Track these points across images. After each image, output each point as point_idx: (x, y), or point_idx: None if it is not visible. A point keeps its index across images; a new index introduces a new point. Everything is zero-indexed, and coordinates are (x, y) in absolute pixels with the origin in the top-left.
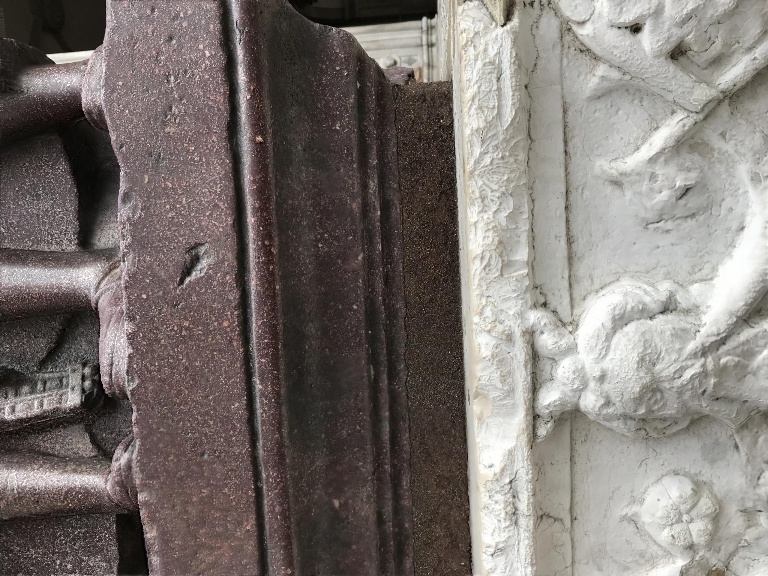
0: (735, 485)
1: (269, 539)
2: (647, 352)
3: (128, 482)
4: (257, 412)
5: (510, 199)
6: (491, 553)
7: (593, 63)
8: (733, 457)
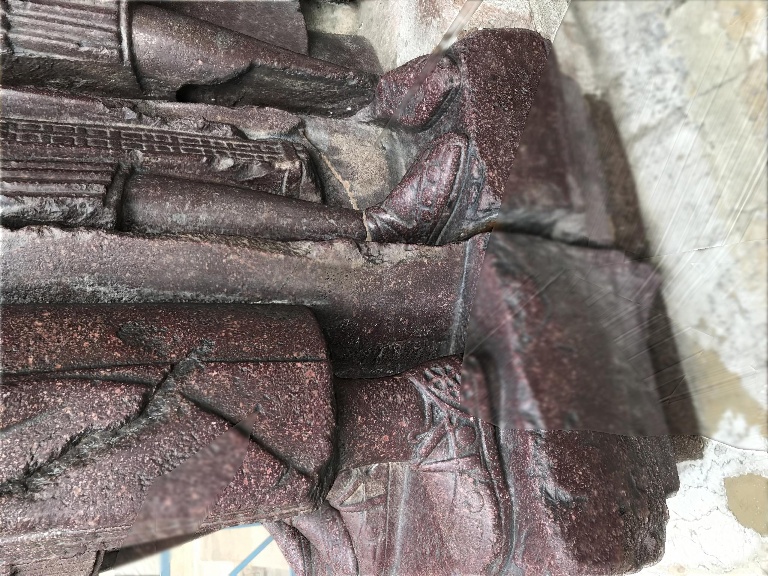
0: None
1: None
2: None
3: None
4: None
5: None
6: None
7: None
8: None
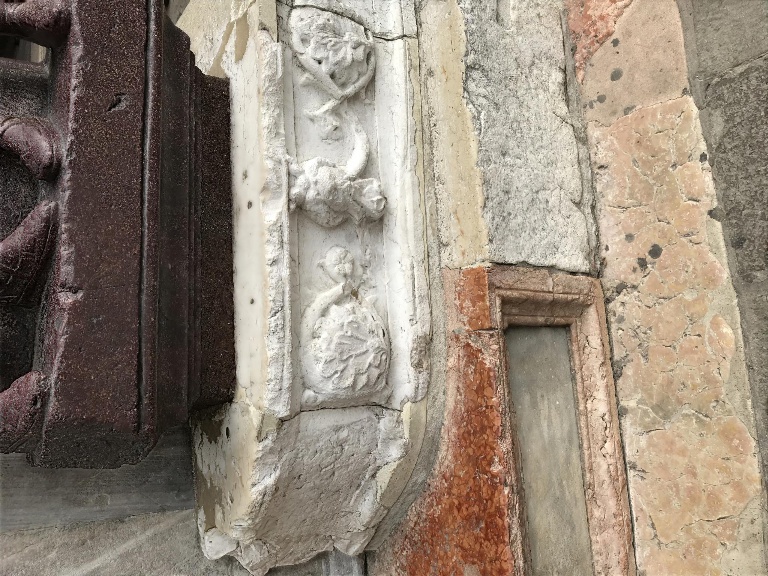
0: (358, 253)
1: (146, 262)
2: (332, 174)
3: (54, 219)
4: (145, 188)
5: (278, 108)
6: (271, 263)
7: (303, 72)
8: (356, 241)
